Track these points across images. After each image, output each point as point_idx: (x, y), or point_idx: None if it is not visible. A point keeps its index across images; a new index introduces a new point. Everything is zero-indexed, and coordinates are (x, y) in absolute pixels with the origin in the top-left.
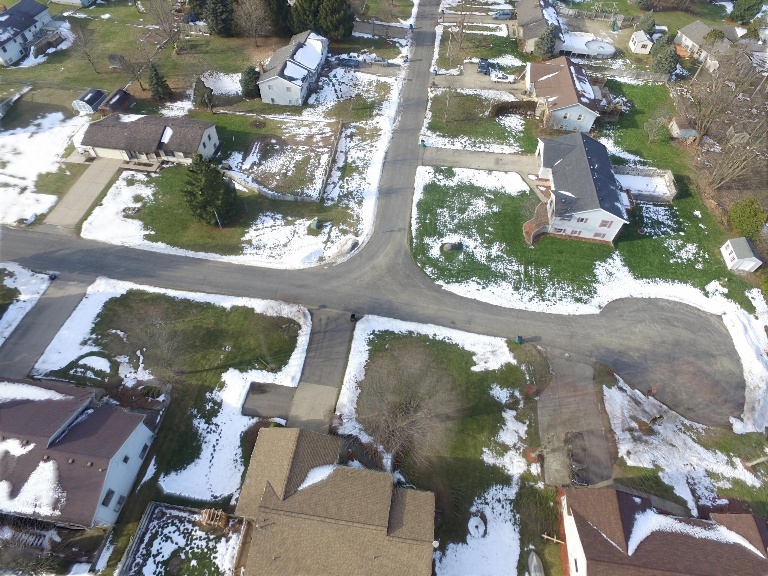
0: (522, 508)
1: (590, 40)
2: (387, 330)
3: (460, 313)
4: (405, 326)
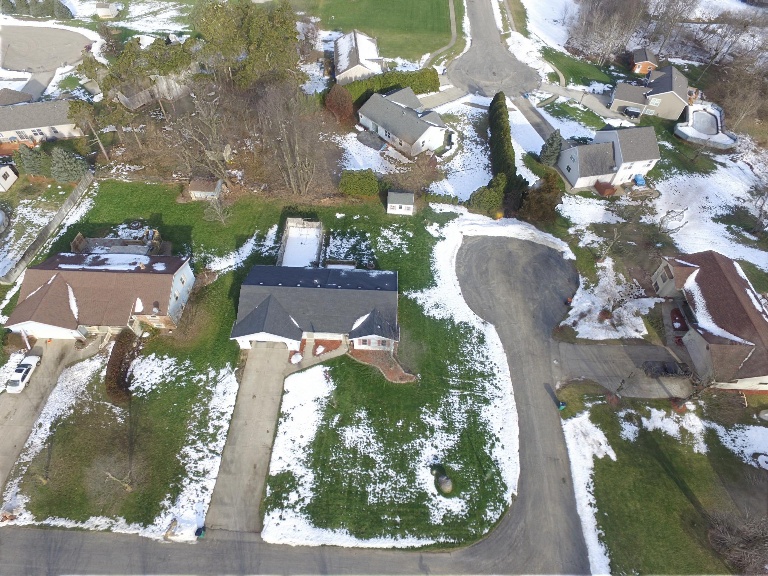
0: (729, 421)
1: None
2: (612, 575)
3: (547, 471)
4: (595, 548)
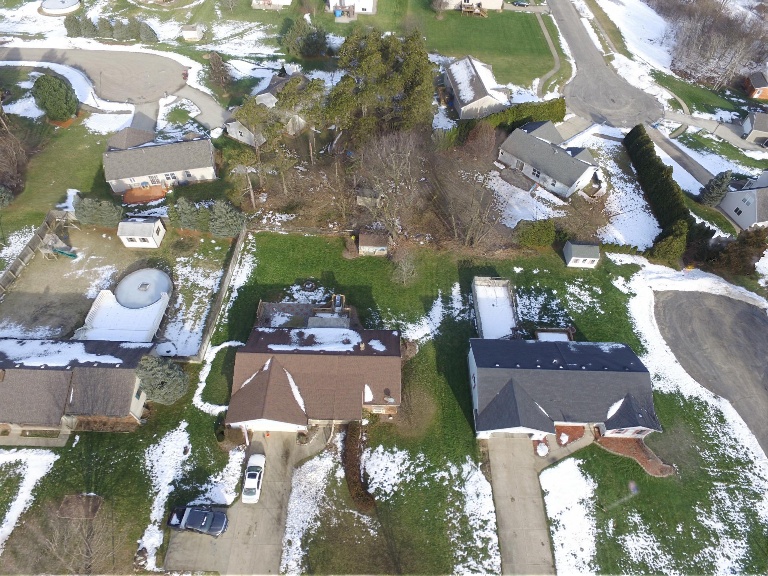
0: None
1: (114, 298)
2: None
3: None
4: None
